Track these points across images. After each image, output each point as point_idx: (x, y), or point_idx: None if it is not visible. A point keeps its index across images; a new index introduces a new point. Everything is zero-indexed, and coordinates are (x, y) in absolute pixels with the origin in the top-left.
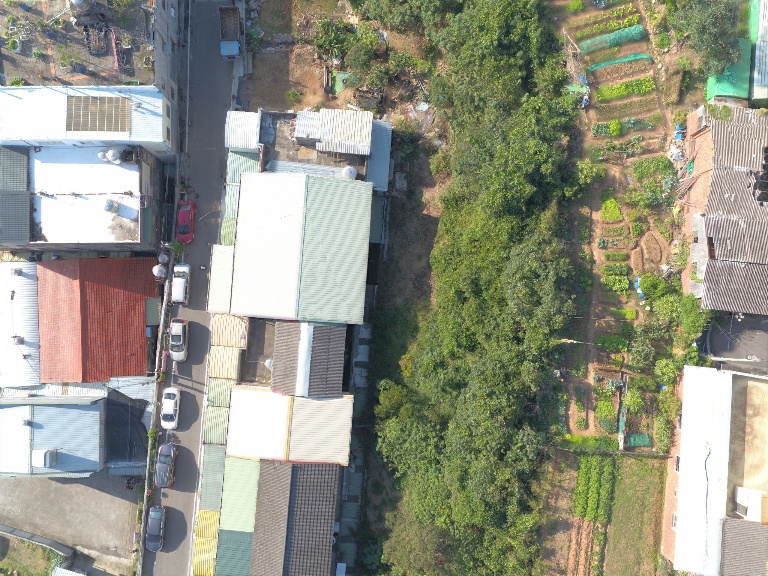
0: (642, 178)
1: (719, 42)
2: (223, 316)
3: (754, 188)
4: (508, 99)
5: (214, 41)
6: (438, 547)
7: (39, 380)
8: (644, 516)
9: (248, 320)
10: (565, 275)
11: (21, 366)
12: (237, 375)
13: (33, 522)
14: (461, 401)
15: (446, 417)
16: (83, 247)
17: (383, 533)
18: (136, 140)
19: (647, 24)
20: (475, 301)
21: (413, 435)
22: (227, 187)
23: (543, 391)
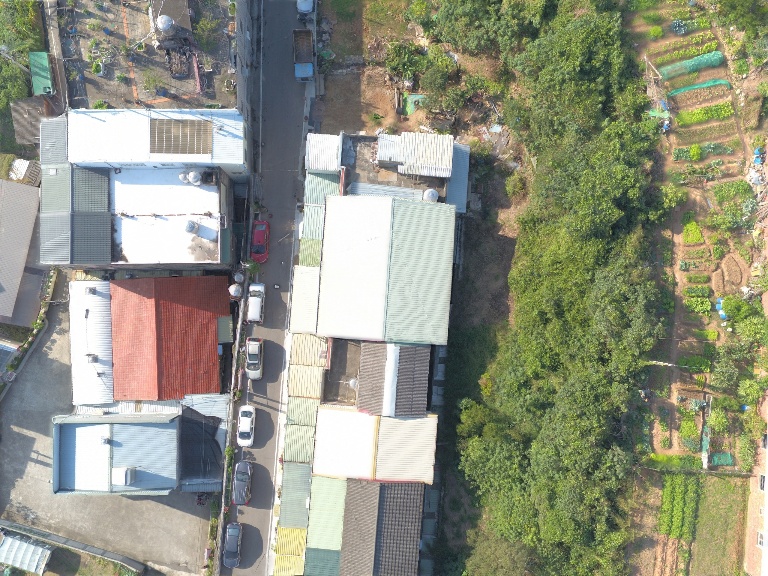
0: (722, 201)
1: None
2: (302, 335)
3: None
4: (589, 124)
5: (286, 63)
6: (526, 565)
7: (113, 398)
8: (727, 534)
9: (331, 340)
10: (653, 298)
11: (95, 384)
12: (321, 395)
13: (104, 538)
14: (546, 421)
15: (527, 436)
16: (160, 267)
17: (462, 550)
18: (218, 162)
19: (725, 50)
20: (558, 322)
21: (497, 454)
22: (305, 208)
23: (627, 411)
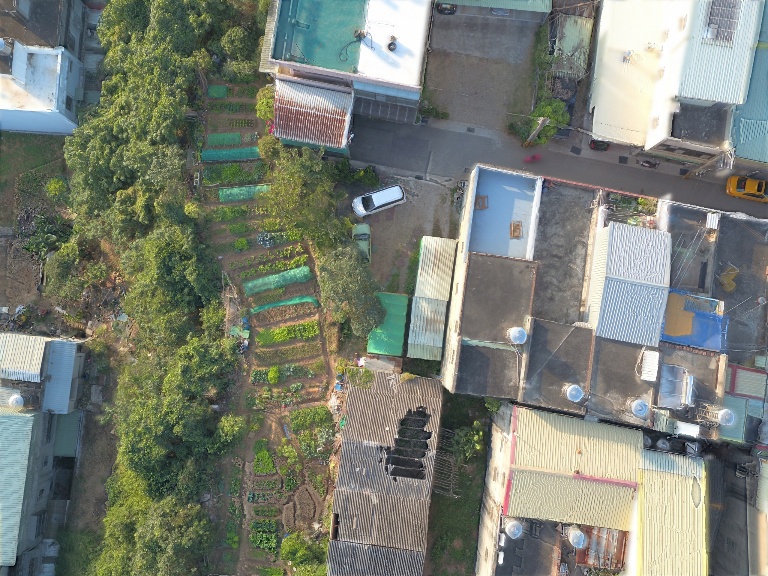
0: (298, 430)
1: (359, 306)
2: None
3: (386, 463)
4: (171, 338)
5: None
6: None
7: None
8: None
9: None
10: (187, 546)
11: None
12: None
13: None
14: None
15: None
16: None
17: None
18: None
19: (315, 265)
20: (125, 549)
21: None
22: None
23: None
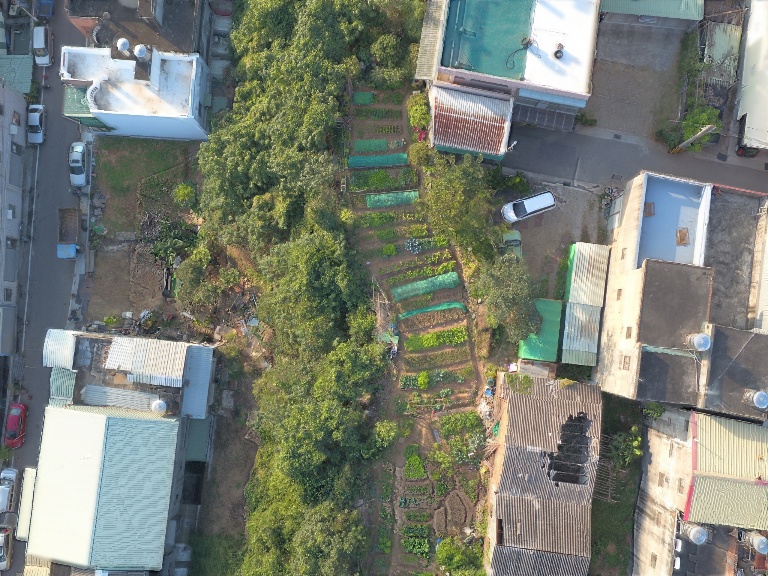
0: (449, 435)
1: None
2: None
3: (549, 468)
4: (318, 343)
5: (57, 237)
6: None
7: None
8: None
9: None
10: (350, 551)
11: None
12: None
13: None
14: None
15: None
16: None
17: None
18: None
19: (463, 271)
20: (274, 554)
21: None
22: (50, 401)
23: None
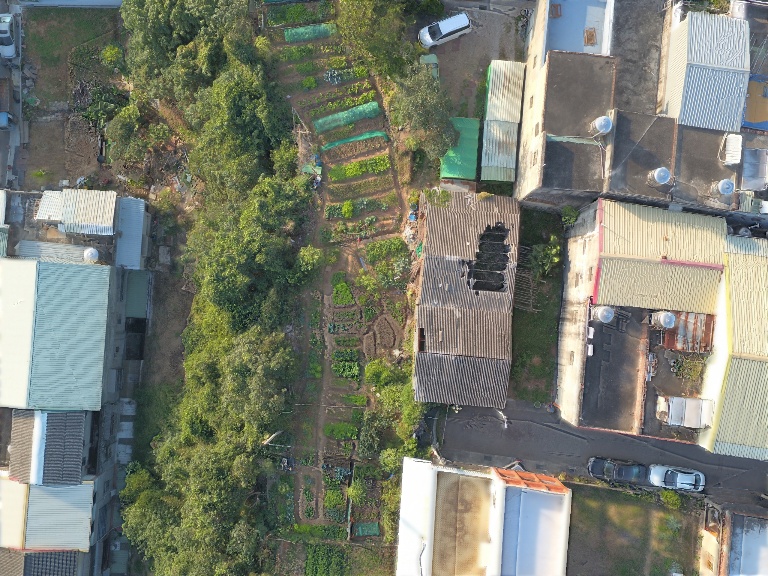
0: (374, 261)
1: (434, 126)
2: None
3: (468, 277)
4: (243, 180)
5: None
6: None
7: None
8: None
9: None
10: (276, 368)
11: None
12: None
13: None
14: None
15: None
16: None
17: None
18: None
19: (383, 101)
20: (209, 387)
21: (152, 521)
22: None
23: (273, 480)
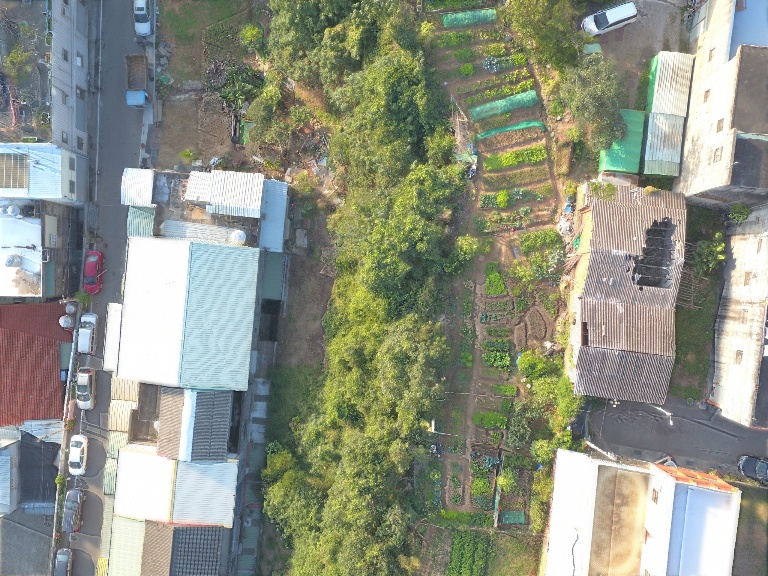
0: (528, 252)
1: (604, 118)
2: None
3: (633, 272)
4: (396, 166)
5: (124, 88)
6: None
7: None
8: None
9: None
10: (436, 357)
11: None
12: (128, 434)
13: None
14: None
15: (331, 482)
16: None
17: None
18: (35, 197)
19: (541, 90)
20: (357, 372)
21: (295, 501)
22: None
23: (420, 465)
